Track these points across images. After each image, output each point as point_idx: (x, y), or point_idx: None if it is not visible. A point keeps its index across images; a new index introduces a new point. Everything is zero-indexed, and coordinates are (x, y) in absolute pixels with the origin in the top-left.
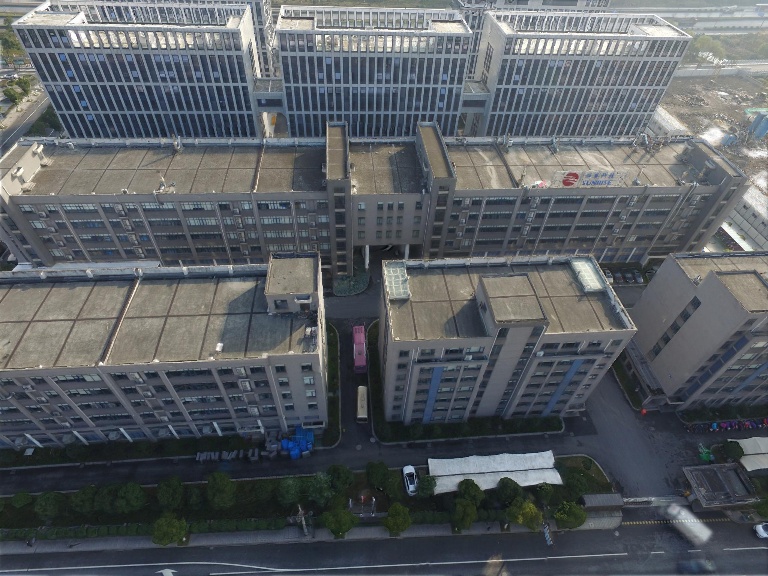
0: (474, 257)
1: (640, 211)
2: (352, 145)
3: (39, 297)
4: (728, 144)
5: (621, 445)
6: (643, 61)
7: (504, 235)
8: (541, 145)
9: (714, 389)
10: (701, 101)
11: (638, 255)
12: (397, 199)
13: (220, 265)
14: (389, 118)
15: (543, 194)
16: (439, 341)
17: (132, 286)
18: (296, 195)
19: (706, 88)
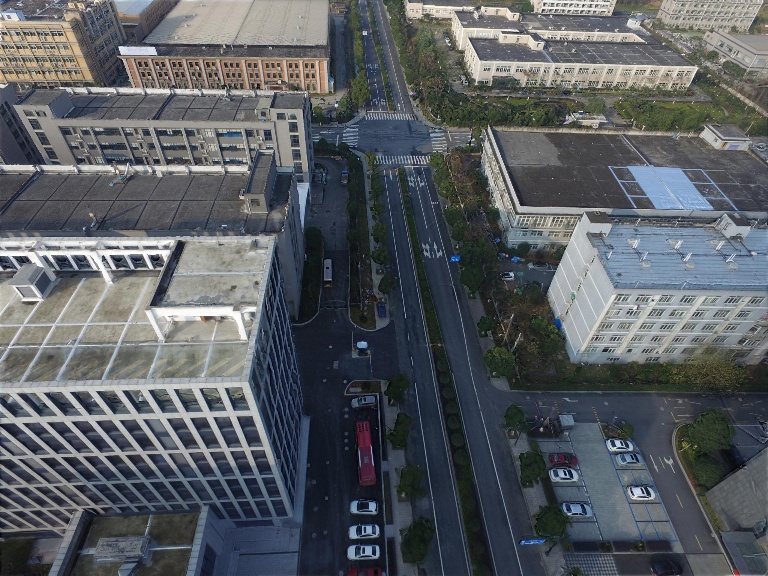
0: None
1: None
2: None
3: (213, 118)
4: None
5: None
6: None
7: None
8: None
9: None
10: None
11: None
12: None
13: (92, 119)
14: None
15: None
16: None
17: (155, 118)
18: None
19: None
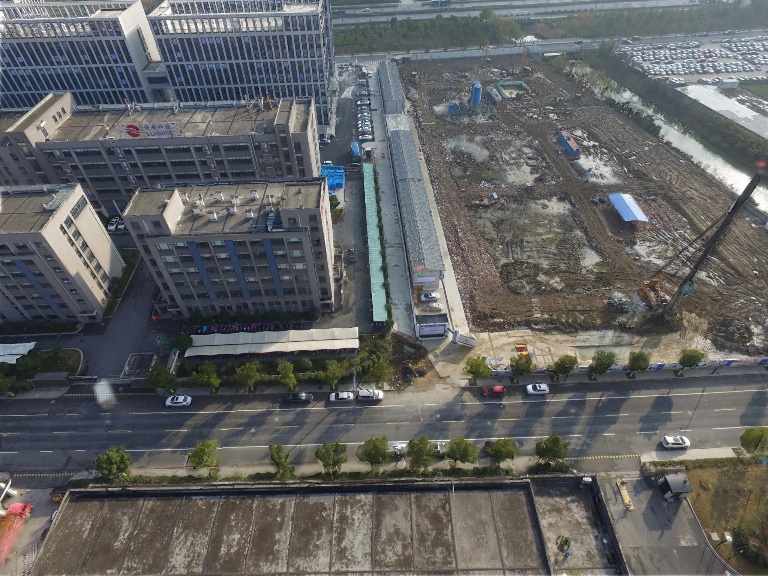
0: None
1: (223, 159)
2: (3, 114)
3: None
4: (452, 113)
5: (115, 342)
6: (286, 35)
7: (116, 184)
8: (169, 109)
9: (190, 295)
10: (464, 77)
11: None
12: None
13: None
14: (85, 95)
15: (119, 145)
16: None
17: None
18: None
19: (481, 66)
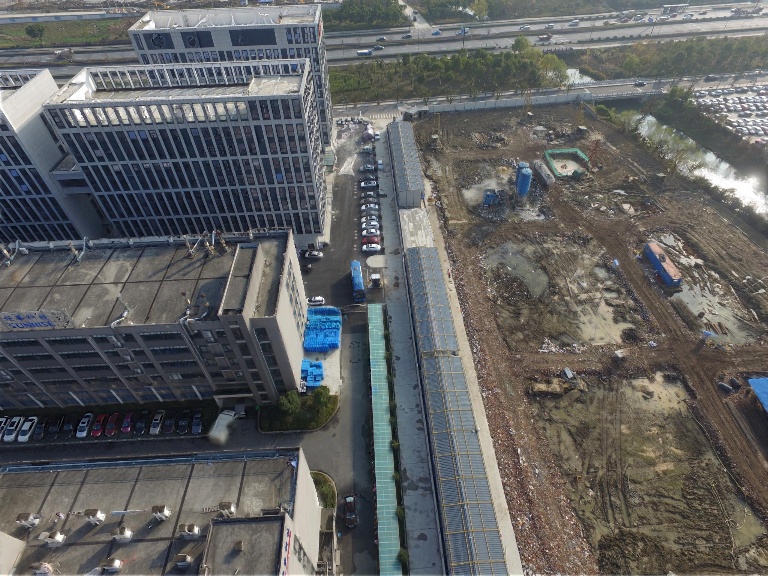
0: None
1: (143, 350)
2: None
3: None
4: (489, 203)
5: None
6: (253, 126)
7: None
8: None
9: None
10: (500, 141)
11: (209, 392)
12: None
13: None
14: None
15: None
16: None
17: None
18: None
19: (520, 122)
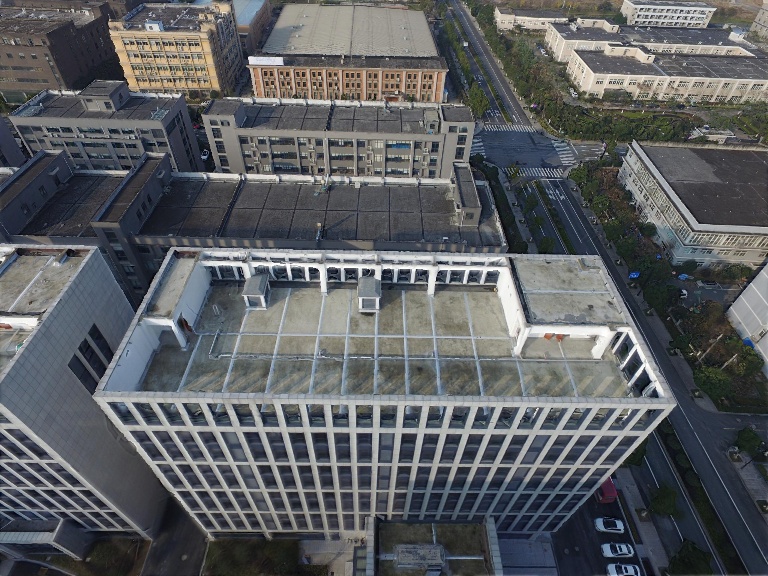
0: (96, 118)
1: None
2: None
3: (381, 129)
4: None
5: None
6: None
7: None
8: None
9: None
10: None
11: None
12: (107, 175)
13: (272, 129)
14: None
15: None
16: (159, 94)
17: None
18: (201, 176)
19: None
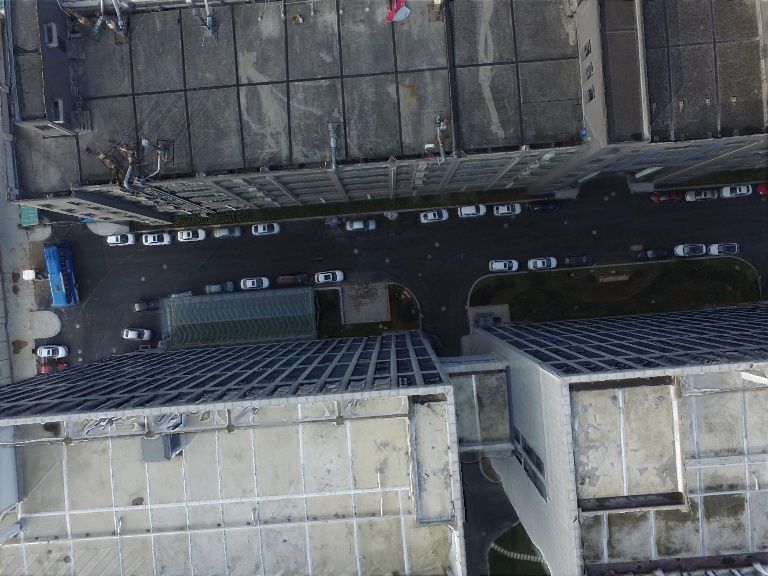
0: None
1: None
2: (758, 128)
3: None
4: None
5: None
6: None
7: None
8: (360, 160)
9: None
10: None
11: None
12: None
13: None
14: None
15: None
16: None
17: None
18: None
19: None
